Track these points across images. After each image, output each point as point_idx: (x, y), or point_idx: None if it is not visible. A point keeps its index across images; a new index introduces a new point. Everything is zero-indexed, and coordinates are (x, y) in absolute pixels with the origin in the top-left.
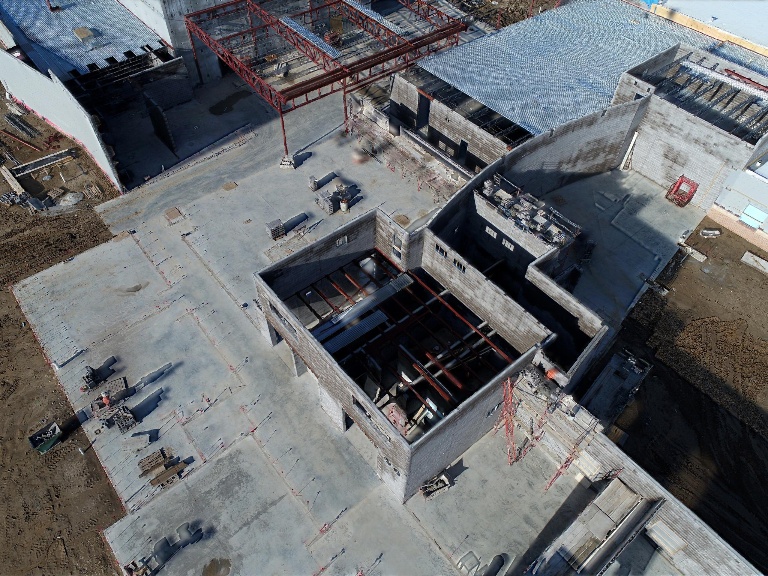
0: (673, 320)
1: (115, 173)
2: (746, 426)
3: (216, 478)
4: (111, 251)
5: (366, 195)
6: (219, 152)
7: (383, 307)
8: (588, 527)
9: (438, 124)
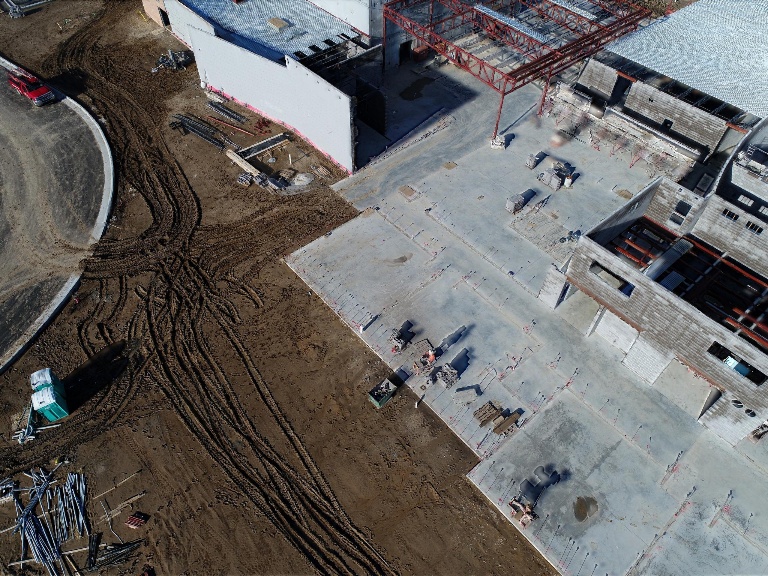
0: None
1: (353, 153)
2: None
3: (551, 427)
4: (364, 226)
5: (582, 172)
6: (426, 134)
7: (676, 268)
8: None
9: (637, 105)
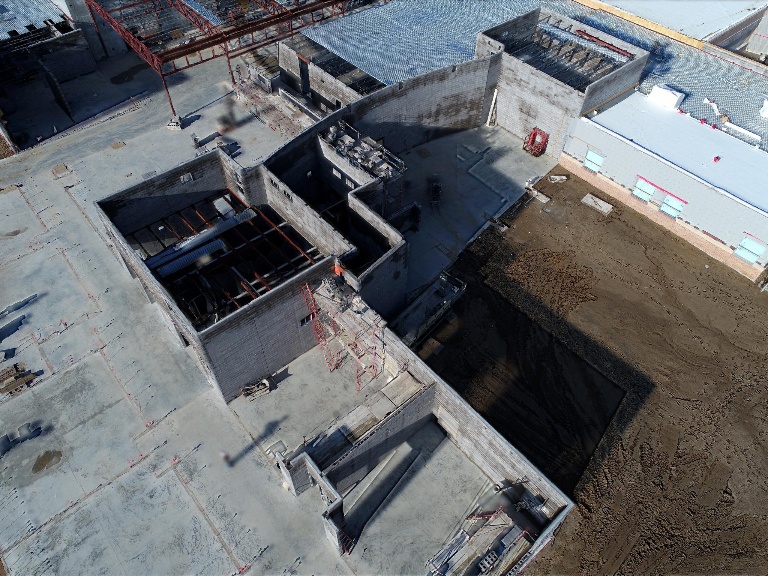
0: (507, 252)
1: (5, 132)
2: (553, 337)
3: (61, 387)
4: None
5: (244, 151)
6: (113, 116)
7: (223, 236)
8: (371, 409)
9: (317, 86)
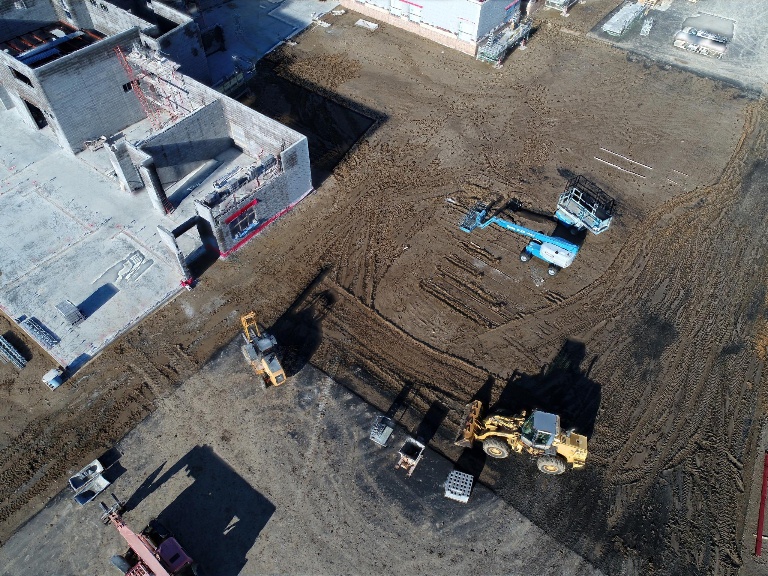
0: (296, 57)
1: None
2: (326, 98)
3: None
4: None
5: None
6: None
7: (58, 47)
8: None
9: None
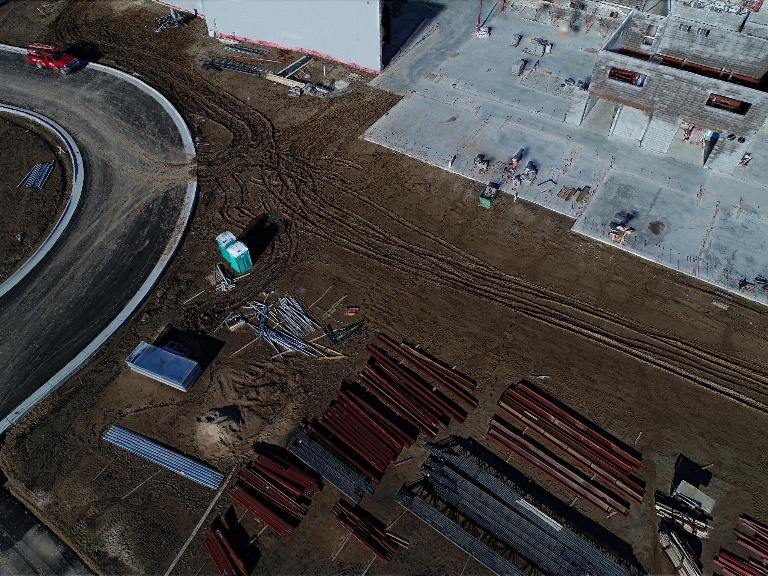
0: None
1: (381, 52)
2: None
3: (612, 191)
4: (411, 104)
5: (554, 42)
6: (423, 38)
7: None
8: None
9: None
